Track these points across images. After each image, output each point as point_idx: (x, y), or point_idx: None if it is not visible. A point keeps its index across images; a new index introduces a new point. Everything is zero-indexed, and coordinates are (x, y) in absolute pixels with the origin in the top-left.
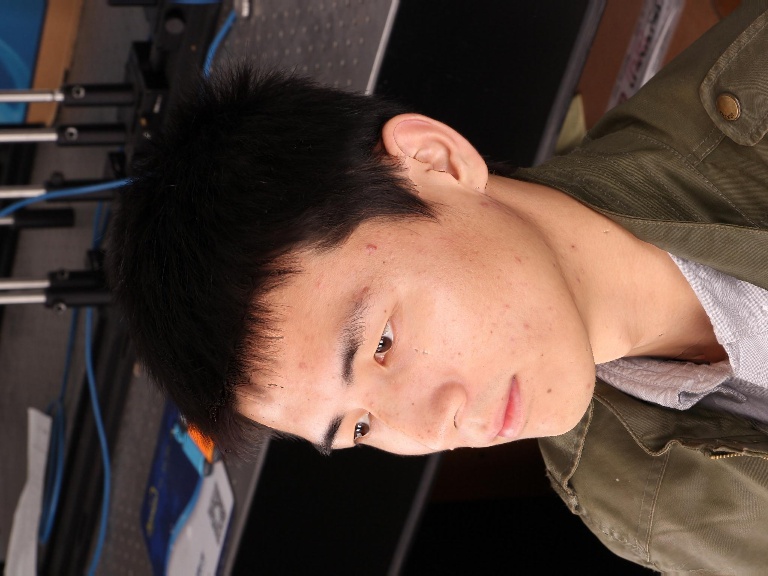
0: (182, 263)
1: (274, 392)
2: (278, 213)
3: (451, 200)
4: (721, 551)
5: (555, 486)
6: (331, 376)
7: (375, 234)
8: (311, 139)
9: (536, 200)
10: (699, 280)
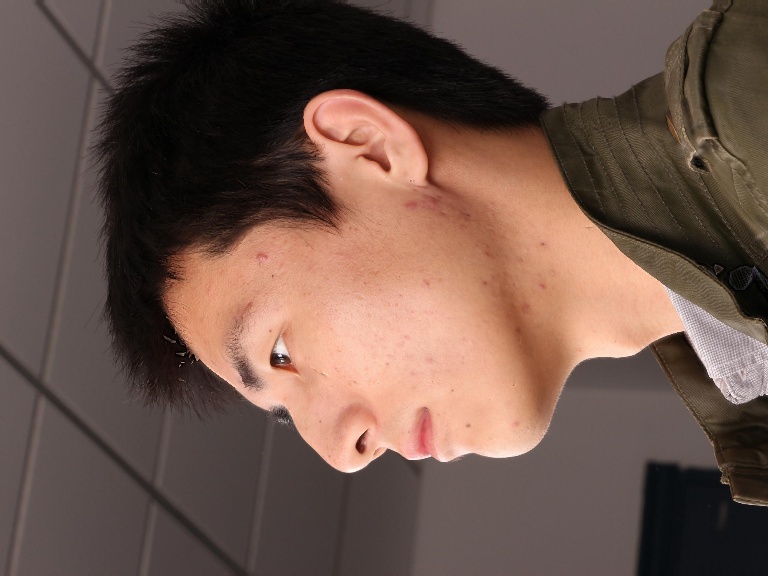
0: (115, 230)
1: None
2: (162, 213)
3: (367, 201)
4: None
5: None
6: (237, 380)
7: (270, 241)
8: (219, 121)
9: (508, 183)
10: (682, 302)
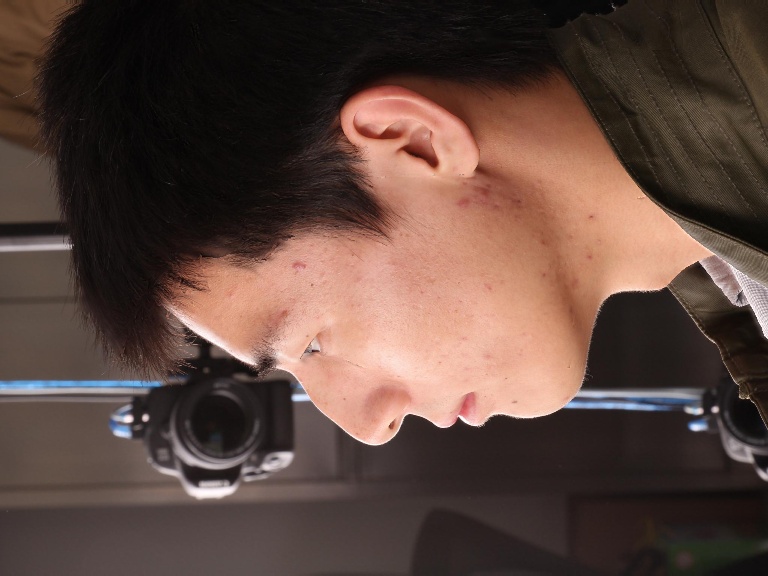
0: (87, 206)
1: None
2: (181, 227)
3: (417, 204)
4: None
5: None
6: None
7: (307, 249)
8: (242, 125)
9: (554, 157)
10: None
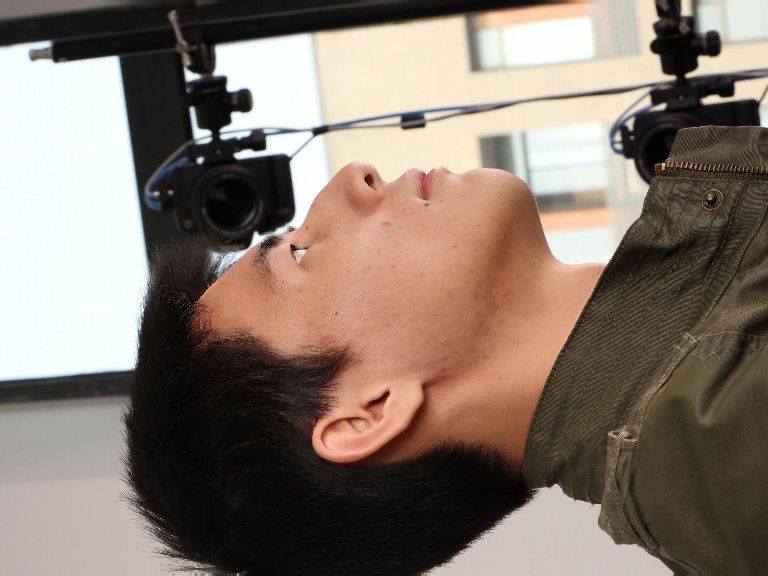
0: None
1: None
2: None
3: None
4: (761, 266)
5: (610, 468)
6: None
7: None
8: None
9: None
10: None
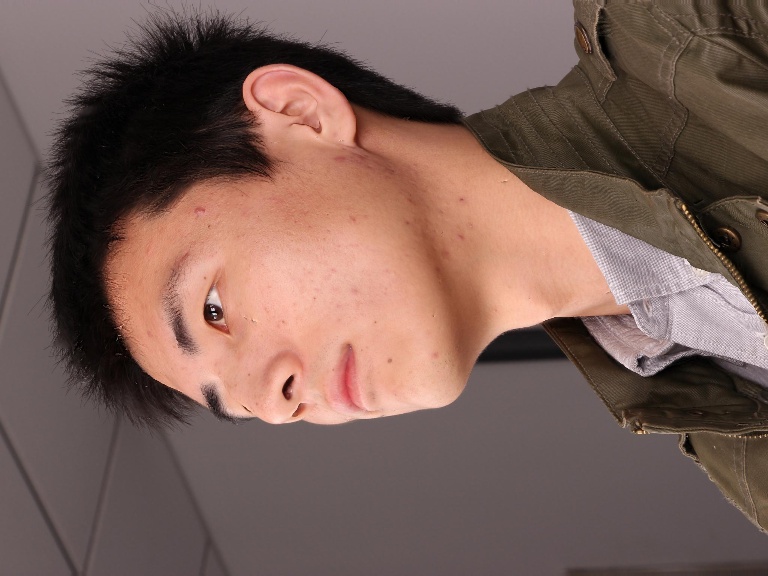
0: None
1: (149, 360)
2: (107, 178)
3: (299, 156)
4: None
5: None
6: (171, 345)
7: (207, 196)
8: (164, 98)
9: (430, 149)
10: (591, 233)
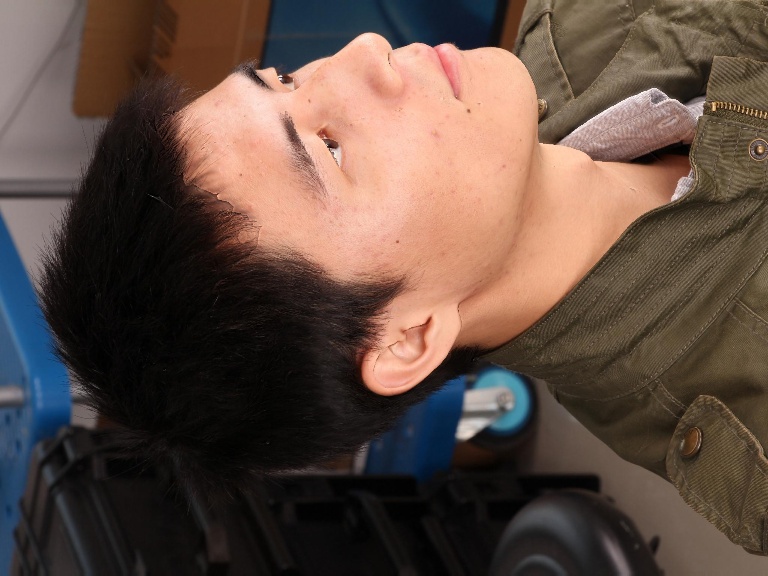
0: None
1: (214, 139)
2: None
3: None
4: None
5: None
6: None
7: None
8: None
9: None
10: None
